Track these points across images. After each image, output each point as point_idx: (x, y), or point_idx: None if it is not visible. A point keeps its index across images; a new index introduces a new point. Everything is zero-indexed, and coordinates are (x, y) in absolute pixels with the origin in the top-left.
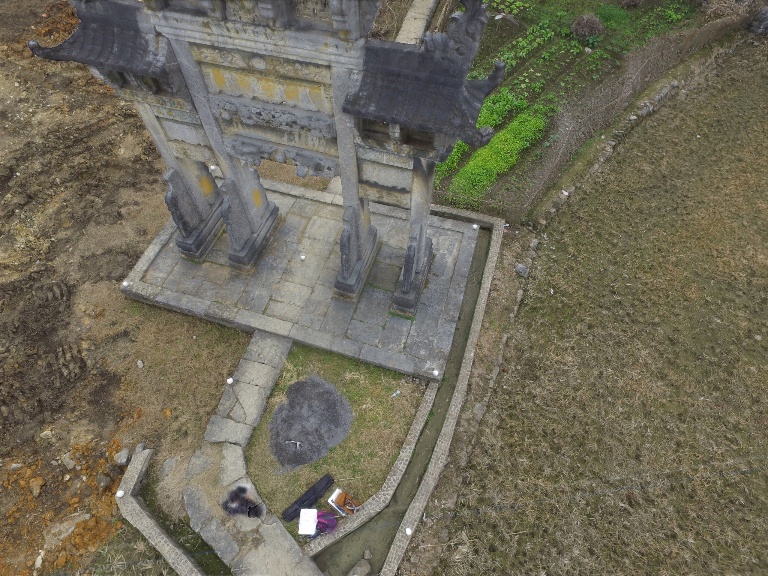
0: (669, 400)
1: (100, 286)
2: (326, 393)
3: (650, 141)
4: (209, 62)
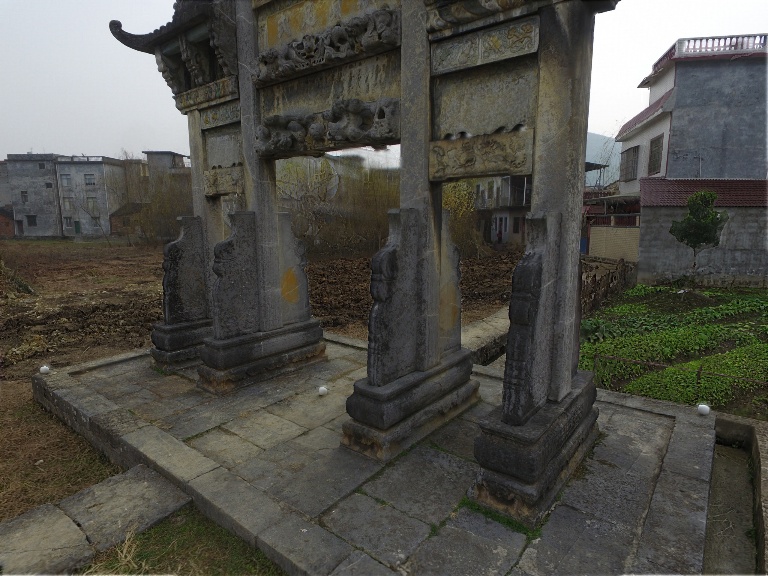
0: None
1: (26, 385)
2: None
3: None
4: (265, 3)
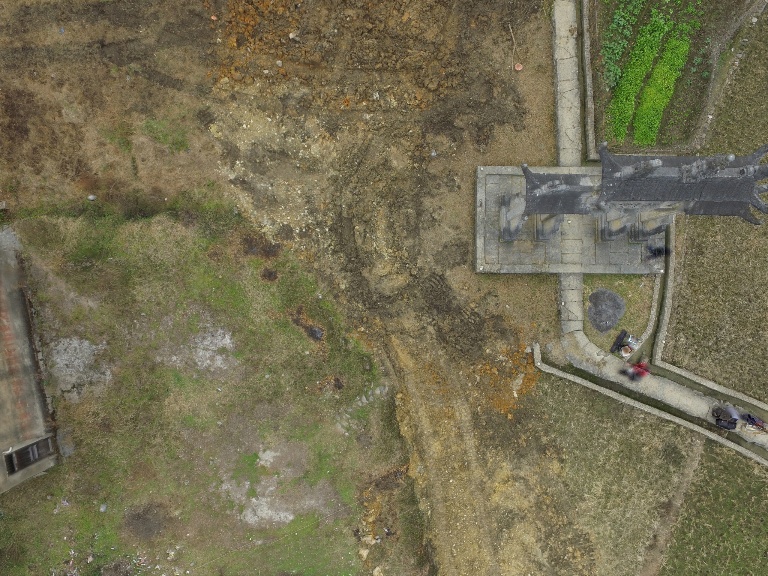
0: (767, 246)
1: (456, 270)
2: (610, 295)
3: (764, 39)
4: None
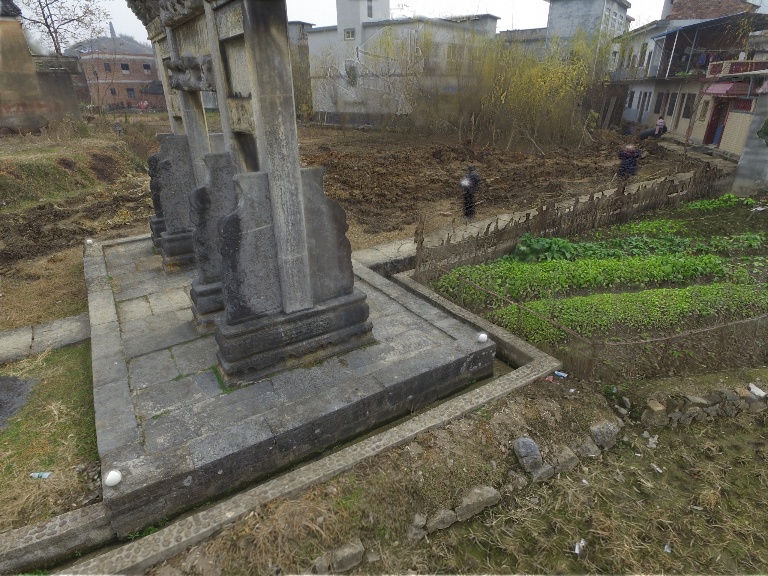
0: None
1: None
2: None
3: None
4: None
